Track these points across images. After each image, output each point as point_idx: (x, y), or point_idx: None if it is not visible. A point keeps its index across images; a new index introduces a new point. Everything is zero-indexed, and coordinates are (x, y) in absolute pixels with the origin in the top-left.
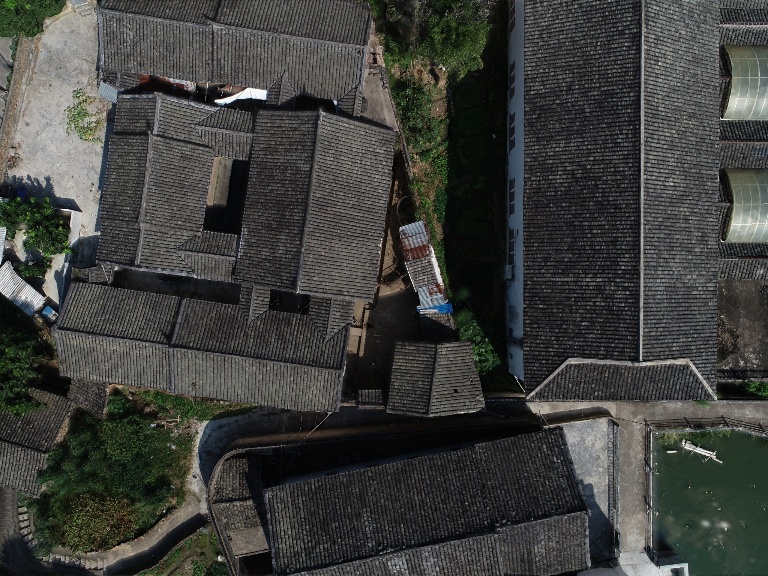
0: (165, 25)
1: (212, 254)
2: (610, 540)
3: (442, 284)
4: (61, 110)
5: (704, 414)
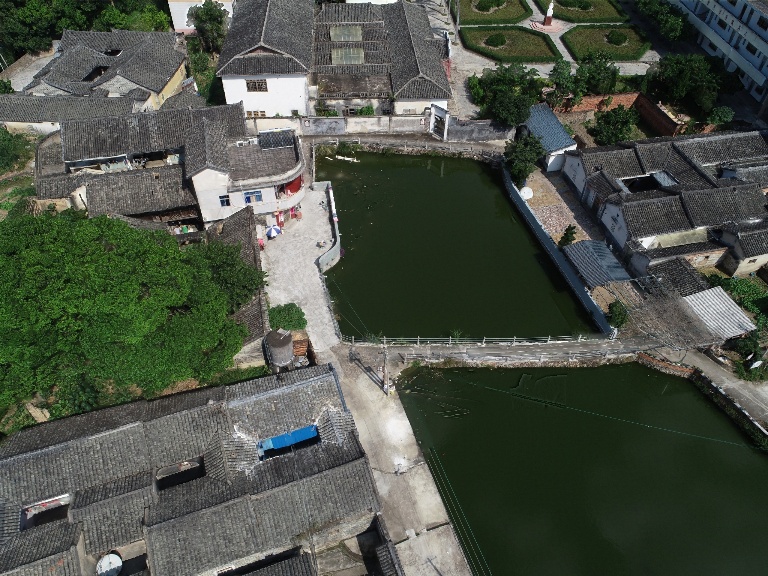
0: (92, 34)
1: (83, 82)
2: None
3: (197, 90)
4: (32, 76)
5: None
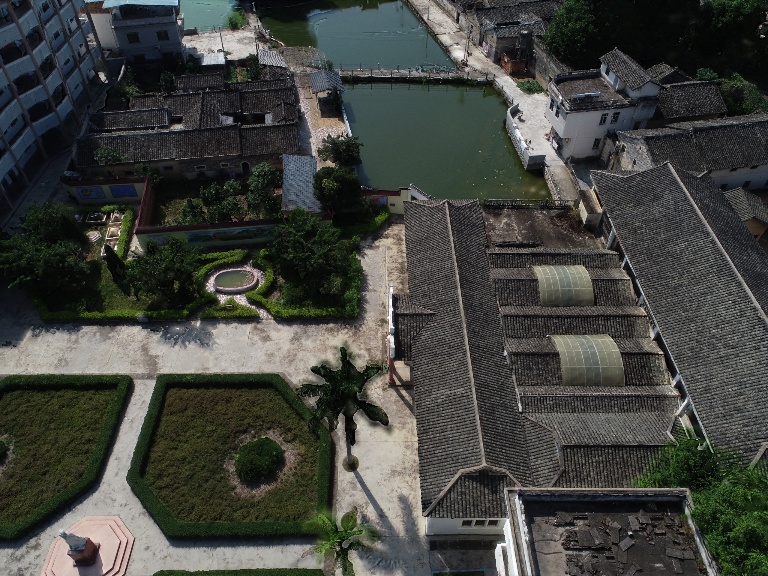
0: None
1: None
2: None
3: None
4: None
5: None
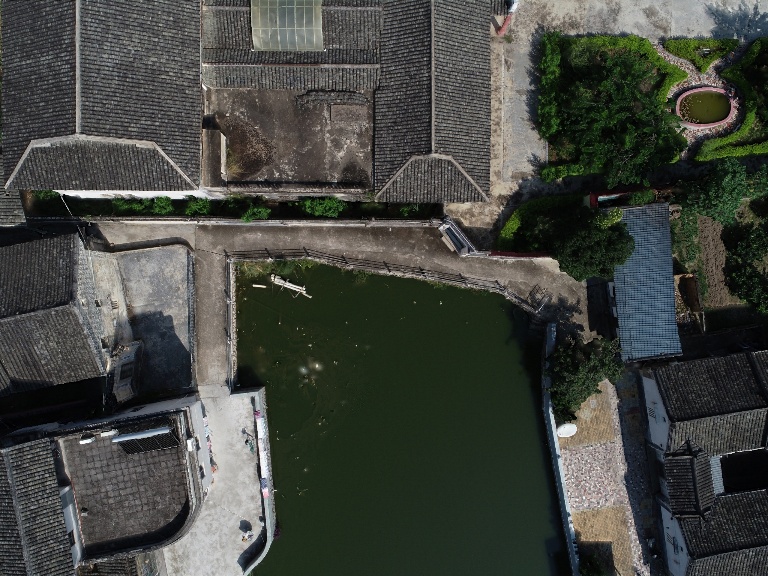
0: None
1: None
2: (190, 373)
3: None
4: None
5: (285, 245)
